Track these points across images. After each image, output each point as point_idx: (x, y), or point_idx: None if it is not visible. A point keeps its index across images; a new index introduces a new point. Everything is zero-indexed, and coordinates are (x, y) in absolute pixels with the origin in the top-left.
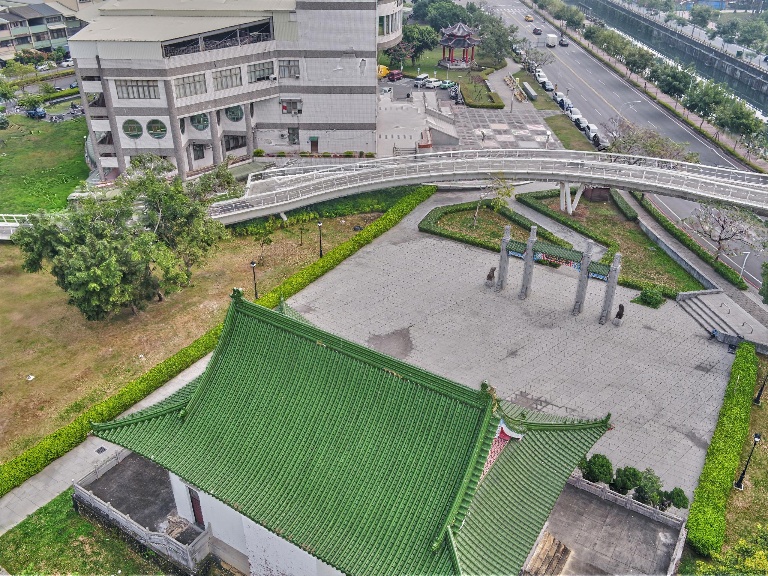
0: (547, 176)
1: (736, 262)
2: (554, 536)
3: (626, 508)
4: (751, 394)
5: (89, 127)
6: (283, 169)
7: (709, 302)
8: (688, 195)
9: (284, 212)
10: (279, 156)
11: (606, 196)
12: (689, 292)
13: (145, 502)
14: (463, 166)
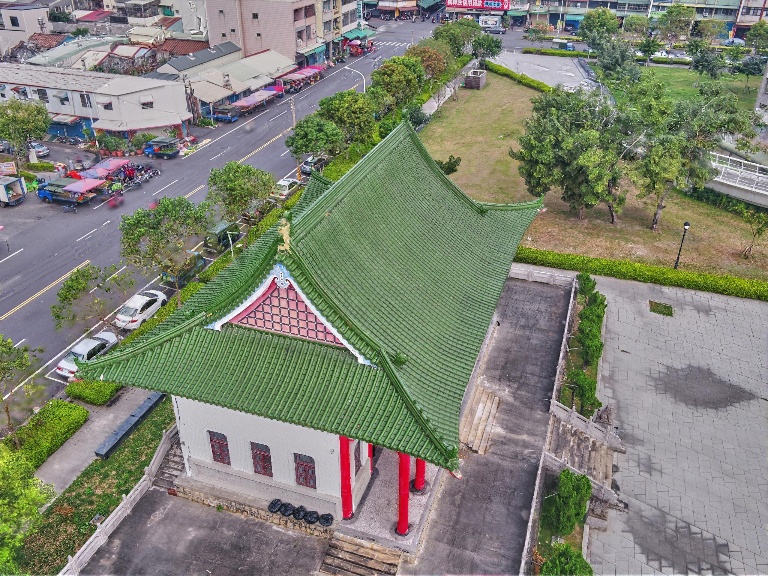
0: None
1: None
2: (409, 573)
3: None
4: None
5: (765, 72)
6: None
7: None
8: None
9: None
10: None
11: None
12: None
13: None
14: None
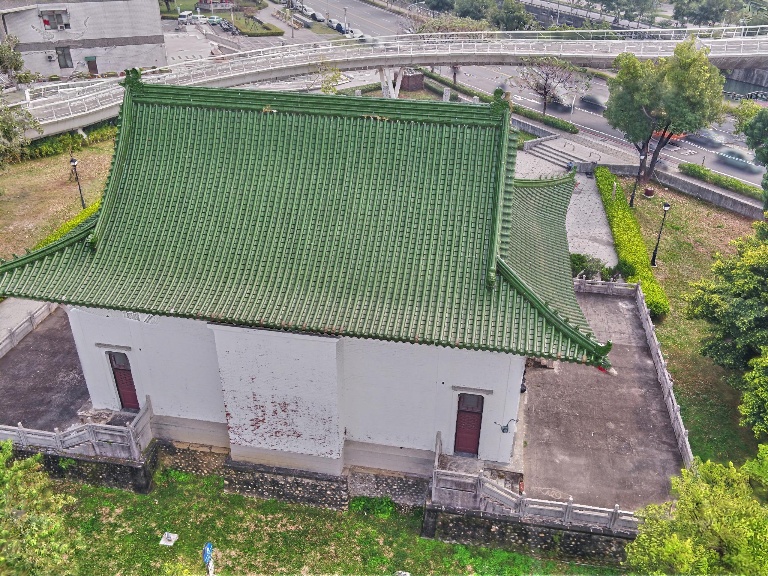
0: (367, 62)
1: (558, 117)
2: None
3: (580, 292)
4: (625, 199)
5: None
6: (66, 83)
7: (553, 145)
8: (506, 58)
9: (82, 128)
10: (52, 80)
11: (421, 84)
12: (534, 140)
13: (33, 413)
14: (277, 63)
